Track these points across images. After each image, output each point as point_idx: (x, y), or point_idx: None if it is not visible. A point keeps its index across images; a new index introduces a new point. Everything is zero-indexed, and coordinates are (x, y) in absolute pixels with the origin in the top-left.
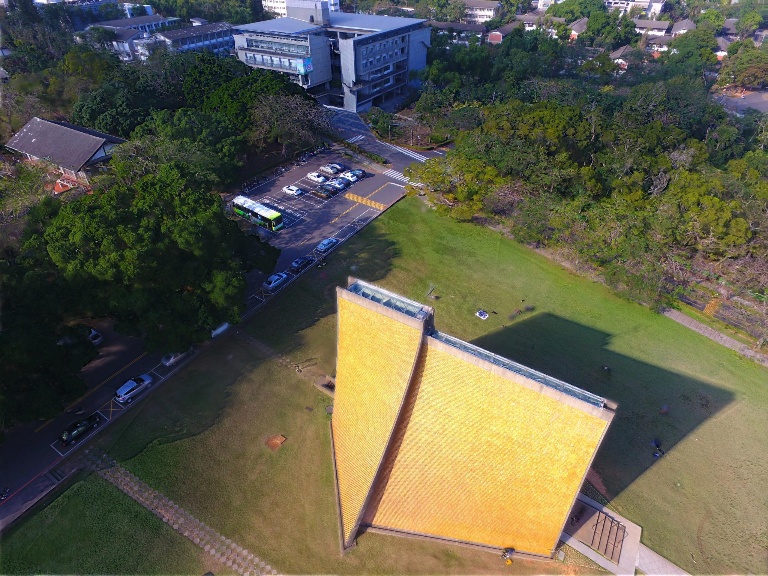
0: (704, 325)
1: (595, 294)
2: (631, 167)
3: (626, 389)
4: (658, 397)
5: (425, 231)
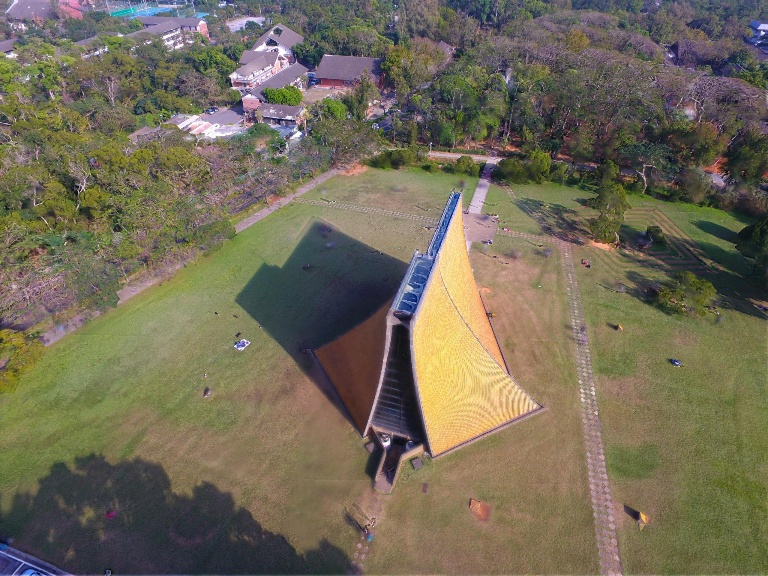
0: (245, 220)
1: (205, 267)
2: (39, 183)
3: (326, 260)
4: (329, 247)
5: (29, 425)
